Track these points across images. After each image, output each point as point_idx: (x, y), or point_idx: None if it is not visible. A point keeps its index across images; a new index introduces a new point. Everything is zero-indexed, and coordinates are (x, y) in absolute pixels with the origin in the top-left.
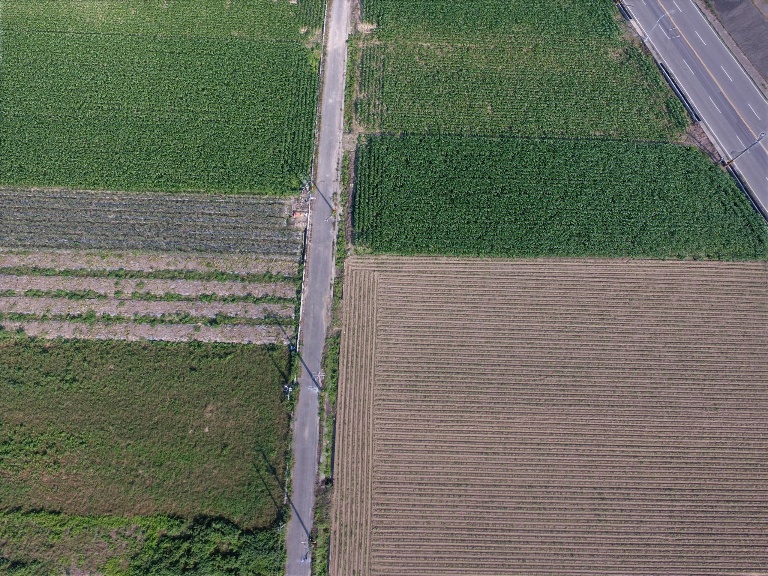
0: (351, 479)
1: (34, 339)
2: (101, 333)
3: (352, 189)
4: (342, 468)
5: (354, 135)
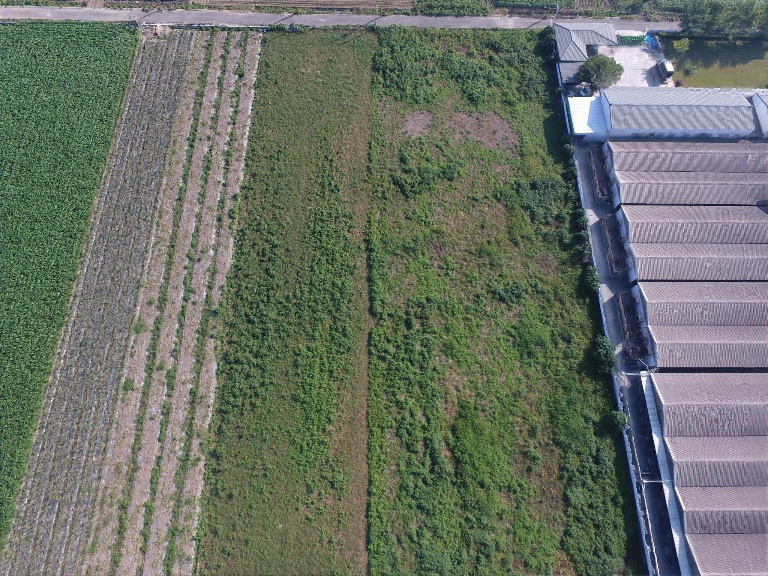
0: (351, 0)
1: (242, 187)
2: (242, 143)
3: (141, 1)
4: (344, 4)
5: (89, 1)
